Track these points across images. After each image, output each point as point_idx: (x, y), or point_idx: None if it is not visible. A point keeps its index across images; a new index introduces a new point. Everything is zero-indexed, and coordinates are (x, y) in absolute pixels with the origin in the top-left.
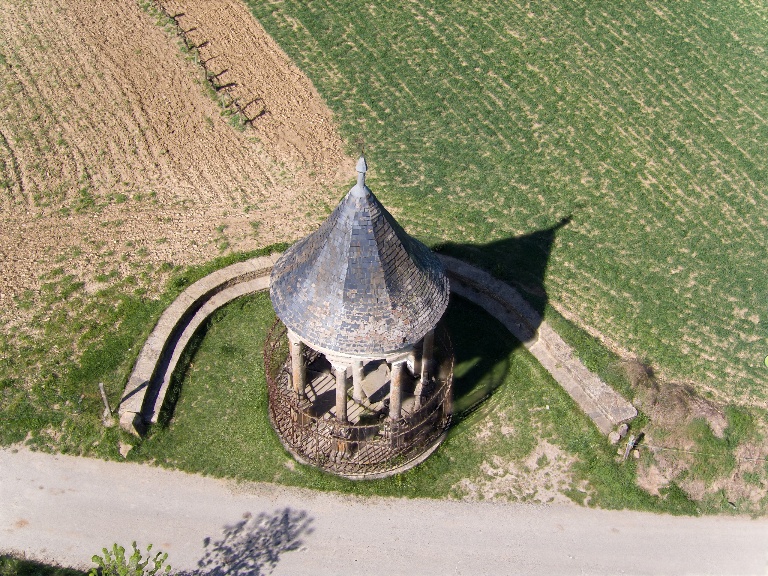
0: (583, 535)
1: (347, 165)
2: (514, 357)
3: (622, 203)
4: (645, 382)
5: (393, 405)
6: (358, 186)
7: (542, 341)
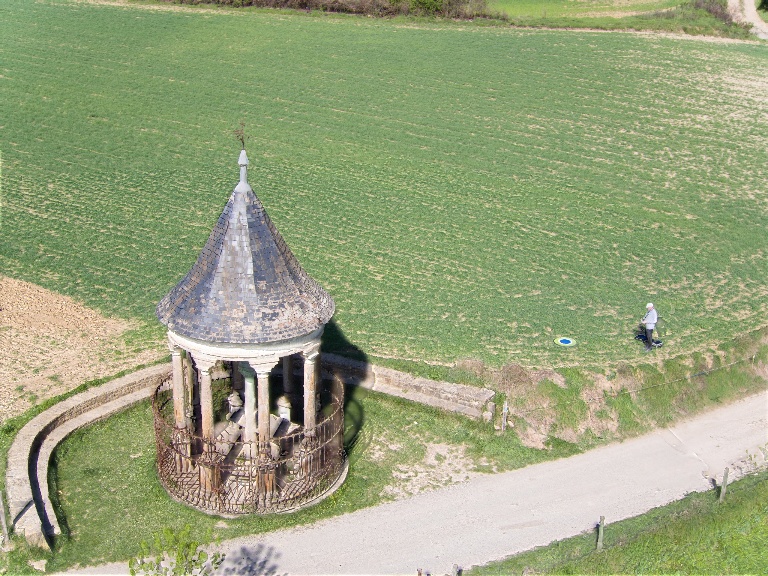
0: (511, 490)
1: (112, 324)
2: (362, 401)
3: (370, 292)
4: None
5: (310, 417)
6: (242, 182)
7: (380, 379)
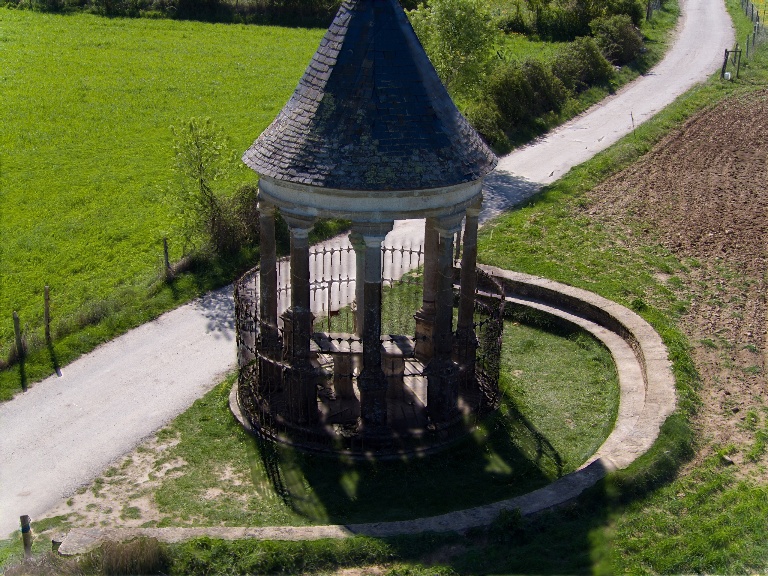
0: None
1: None
2: None
3: None
4: (98, 569)
5: None
6: None
7: None
